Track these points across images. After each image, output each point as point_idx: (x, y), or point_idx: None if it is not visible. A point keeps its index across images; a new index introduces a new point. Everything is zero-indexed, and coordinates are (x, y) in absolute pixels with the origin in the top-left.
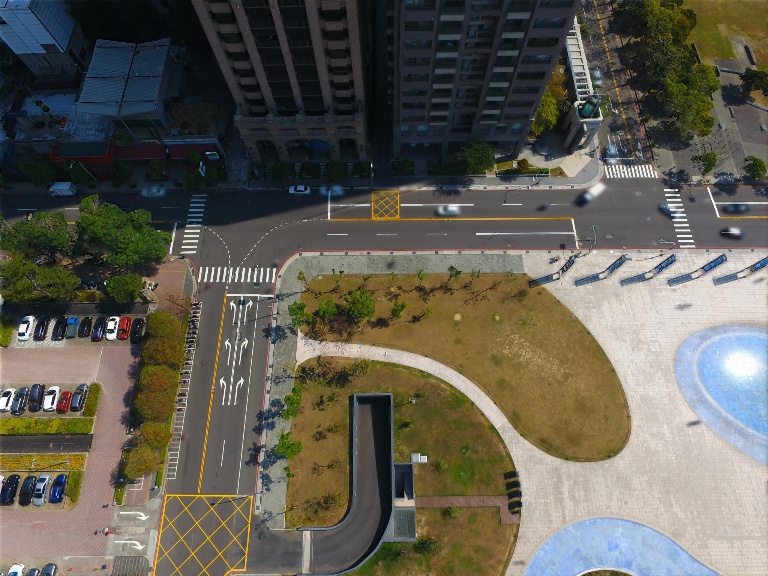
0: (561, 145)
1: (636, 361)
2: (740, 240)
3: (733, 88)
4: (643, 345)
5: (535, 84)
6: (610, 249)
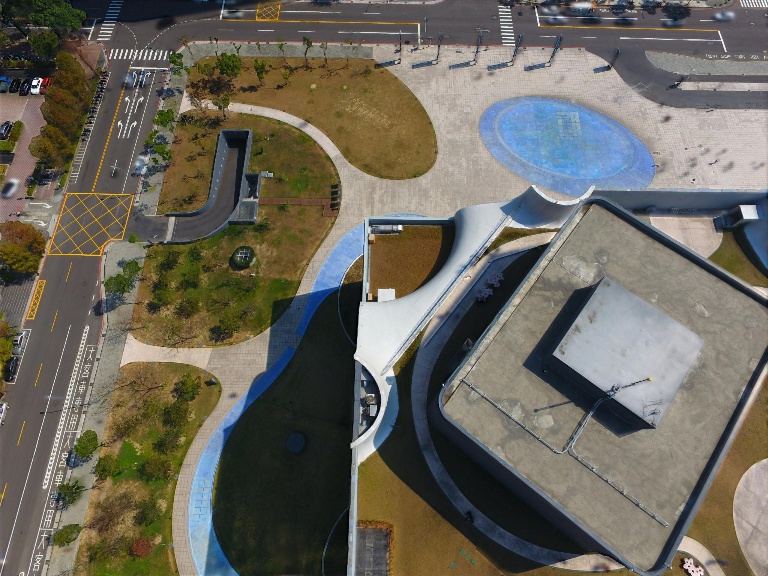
0: None
1: (450, 118)
2: (553, 42)
3: None
4: (458, 108)
5: None
6: (445, 45)
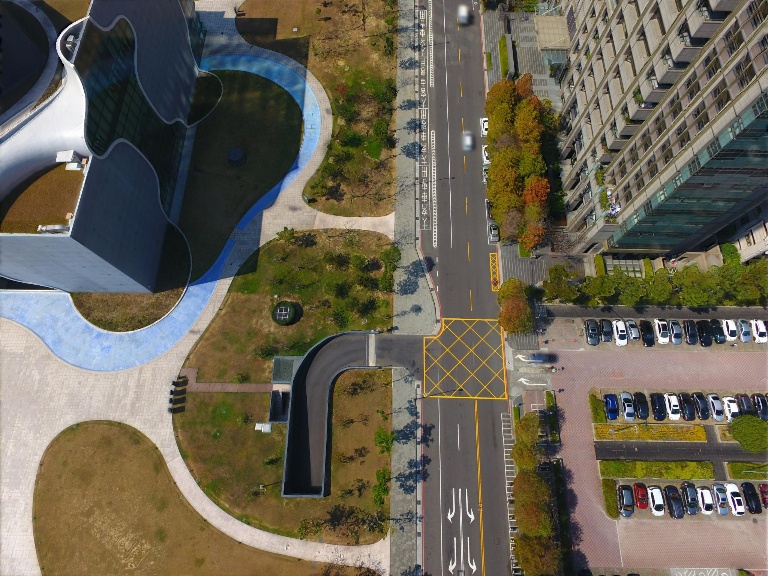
0: None
1: (4, 530)
2: None
3: None
4: None
5: None
6: None
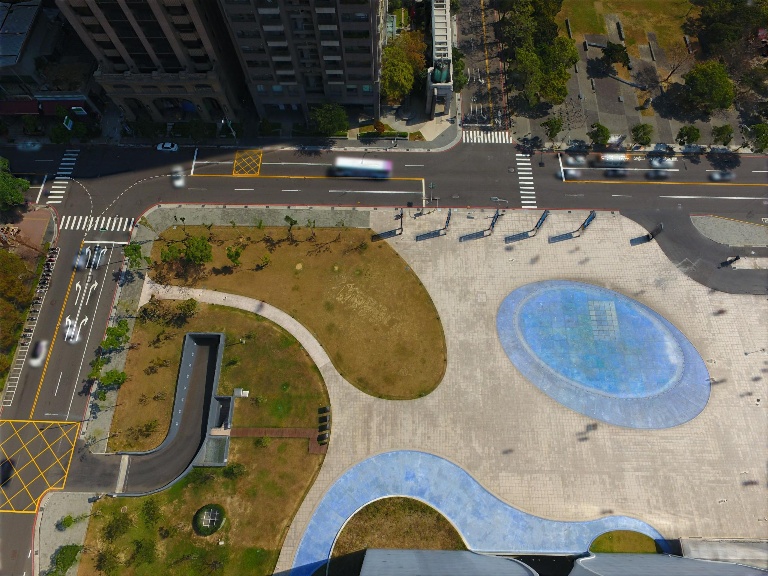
0: (423, 111)
1: (461, 310)
2: (581, 202)
3: (598, 62)
4: (470, 296)
5: (364, 43)
6: (455, 208)
